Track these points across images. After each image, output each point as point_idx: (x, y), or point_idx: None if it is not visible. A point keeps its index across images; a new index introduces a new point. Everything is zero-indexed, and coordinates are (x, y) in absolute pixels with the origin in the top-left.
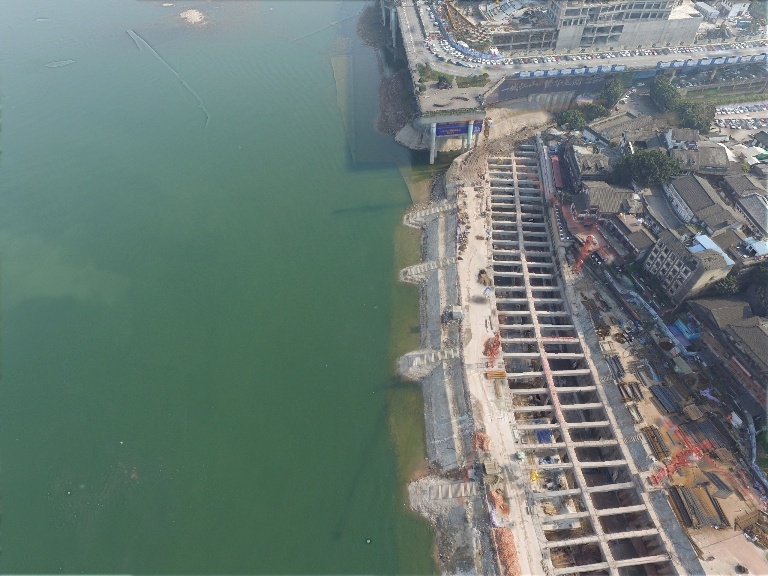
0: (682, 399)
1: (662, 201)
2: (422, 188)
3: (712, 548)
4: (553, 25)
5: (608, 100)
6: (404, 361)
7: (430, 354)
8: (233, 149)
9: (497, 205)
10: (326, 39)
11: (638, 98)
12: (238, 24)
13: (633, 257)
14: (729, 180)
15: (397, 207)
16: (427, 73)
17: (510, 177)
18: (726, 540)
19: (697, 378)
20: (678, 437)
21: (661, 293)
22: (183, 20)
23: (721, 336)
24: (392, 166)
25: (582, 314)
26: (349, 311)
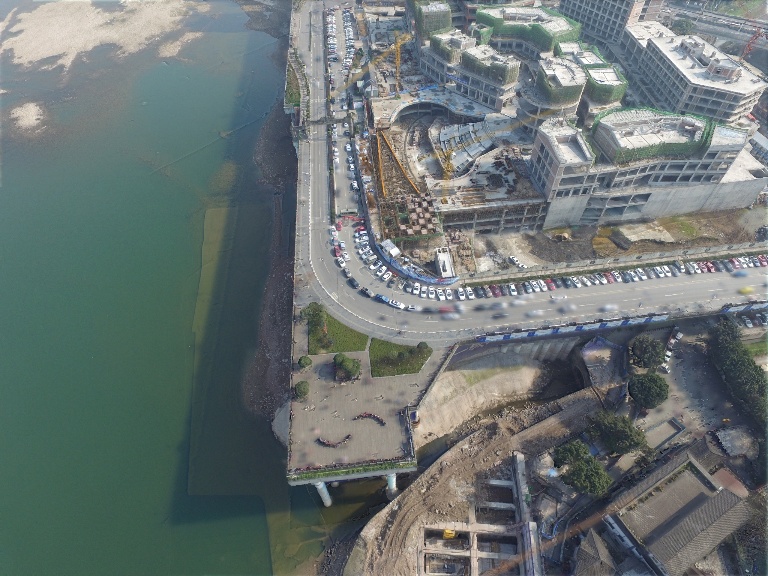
0: None
1: None
2: None
3: None
4: (540, 194)
5: (645, 402)
6: None
7: None
8: None
9: None
10: (208, 167)
11: (687, 355)
12: (87, 133)
13: None
14: None
15: None
16: (320, 328)
17: (467, 570)
18: None
19: None
20: None
21: None
22: (10, 123)
23: None
24: (255, 510)
25: None
26: None
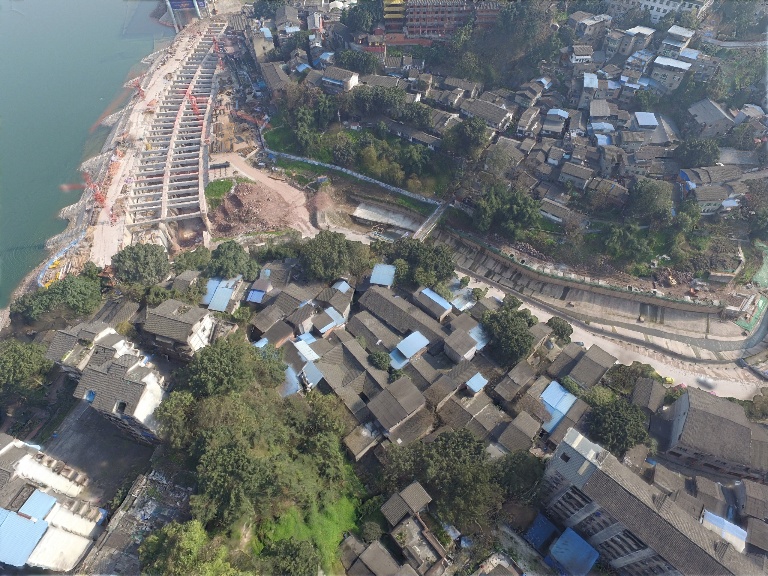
0: (245, 113)
1: (273, 24)
2: (163, 45)
3: (218, 158)
4: None
5: None
6: (105, 118)
7: (119, 111)
8: (23, 18)
9: (200, 46)
10: None
11: None
12: None
13: (248, 53)
14: (309, 9)
15: (140, 54)
16: None
17: None
18: (228, 155)
19: (257, 104)
20: (231, 126)
21: (255, 68)
22: None
23: (262, 76)
24: (149, 35)
25: (217, 87)
26: (82, 101)
